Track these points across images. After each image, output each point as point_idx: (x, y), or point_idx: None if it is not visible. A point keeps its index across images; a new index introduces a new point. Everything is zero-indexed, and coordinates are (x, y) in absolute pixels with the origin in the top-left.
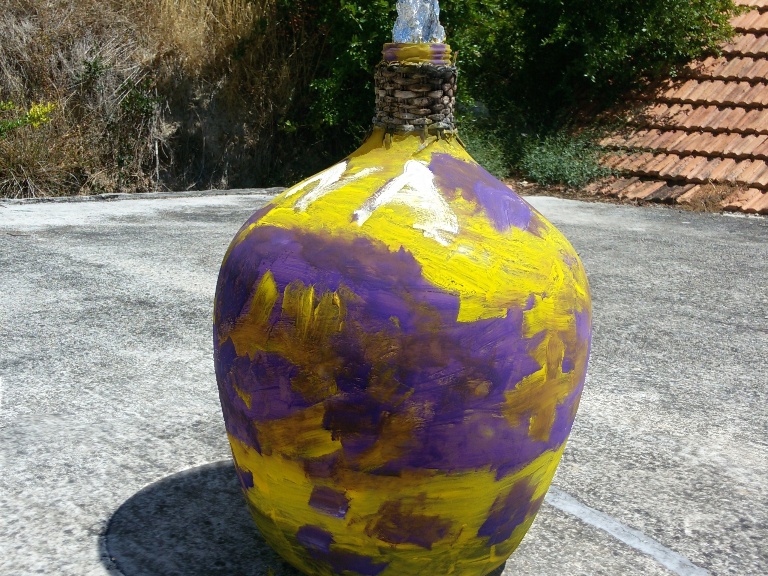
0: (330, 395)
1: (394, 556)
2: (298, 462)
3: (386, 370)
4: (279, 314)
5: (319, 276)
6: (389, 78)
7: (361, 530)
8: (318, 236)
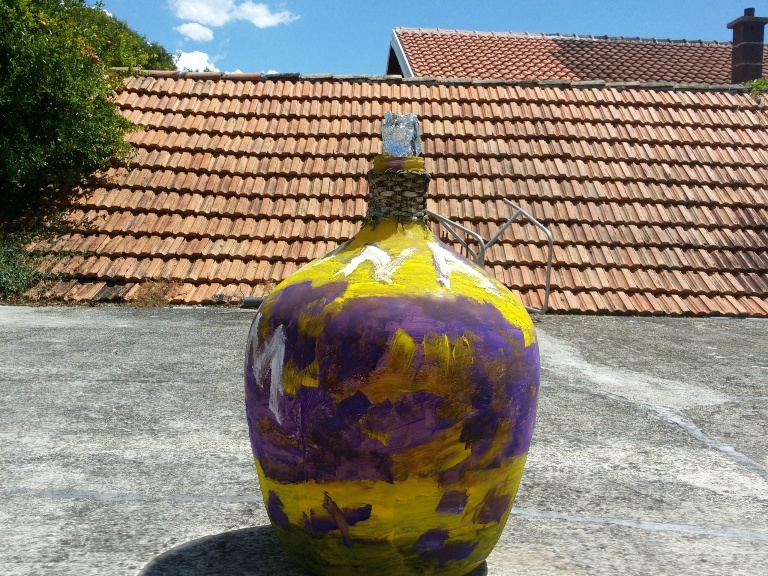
0: (467, 414)
1: (483, 535)
2: (434, 477)
3: (500, 387)
4: (422, 360)
5: (447, 327)
6: (400, 182)
7: (470, 520)
8: (429, 299)
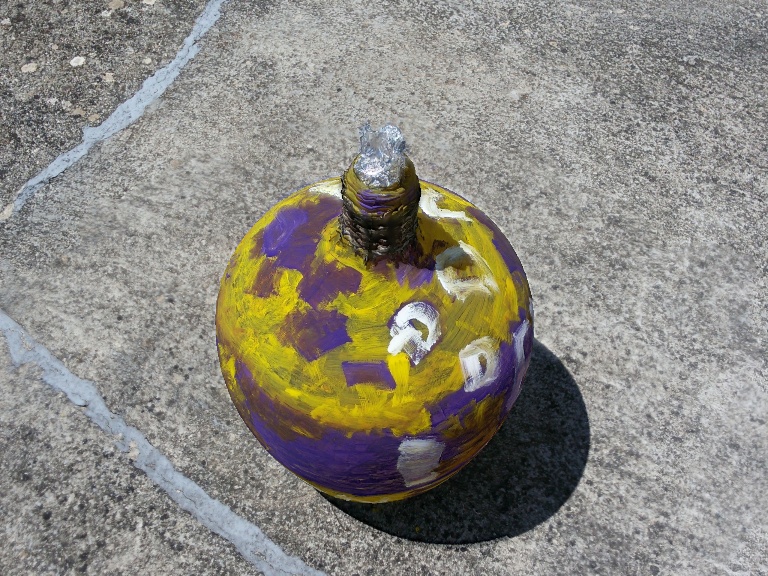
0: None
1: None
2: None
3: None
4: None
5: None
6: None
7: None
8: None
